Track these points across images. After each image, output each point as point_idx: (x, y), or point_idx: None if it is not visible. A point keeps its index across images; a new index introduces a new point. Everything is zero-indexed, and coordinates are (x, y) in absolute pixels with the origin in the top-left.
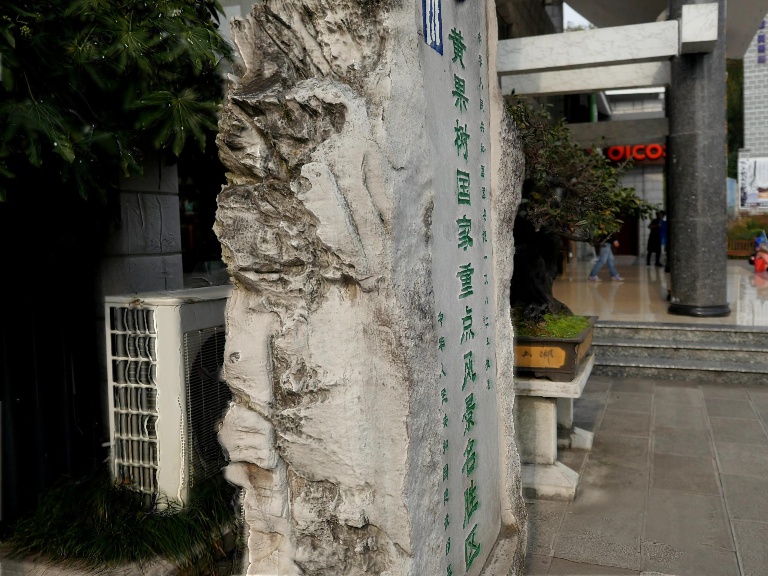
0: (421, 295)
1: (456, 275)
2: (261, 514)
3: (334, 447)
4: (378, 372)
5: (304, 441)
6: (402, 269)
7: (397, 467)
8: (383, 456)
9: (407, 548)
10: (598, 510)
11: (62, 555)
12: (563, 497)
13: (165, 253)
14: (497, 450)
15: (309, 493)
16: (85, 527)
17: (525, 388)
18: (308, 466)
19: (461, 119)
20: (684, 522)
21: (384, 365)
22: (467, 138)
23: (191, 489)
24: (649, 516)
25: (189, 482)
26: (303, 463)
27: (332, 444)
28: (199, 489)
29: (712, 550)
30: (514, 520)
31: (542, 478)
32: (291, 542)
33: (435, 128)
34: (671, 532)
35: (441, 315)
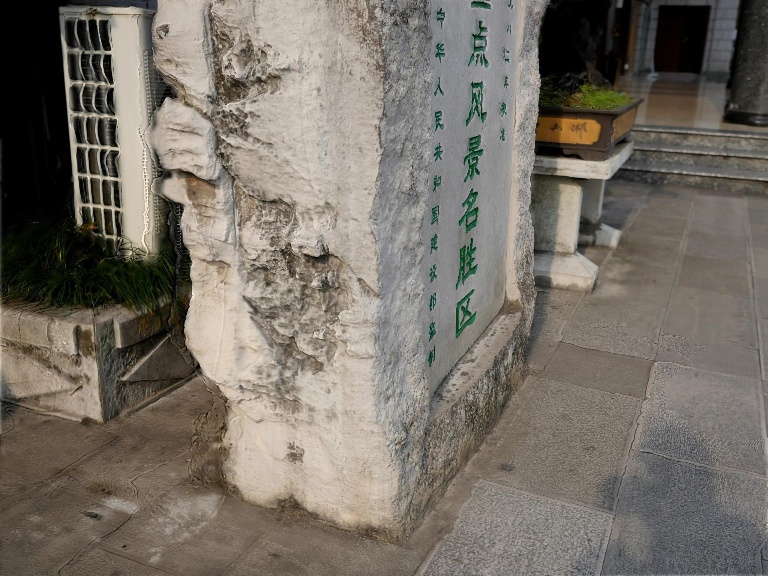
0: None
1: None
2: (201, 237)
3: (287, 154)
4: (344, 56)
5: (250, 145)
6: None
7: (365, 185)
8: (348, 170)
9: (374, 285)
10: (617, 302)
11: (6, 290)
12: (580, 287)
13: None
14: (507, 216)
15: (261, 217)
16: (35, 265)
17: (551, 166)
18: (257, 180)
19: None
20: (710, 319)
21: (353, 47)
22: None
23: (157, 235)
24: (672, 311)
25: (154, 227)
26: (251, 176)
27: (284, 150)
28: (167, 237)
29: (738, 347)
30: (520, 295)
31: (560, 267)
32: (240, 274)
33: None
34: (694, 327)
35: (442, 14)
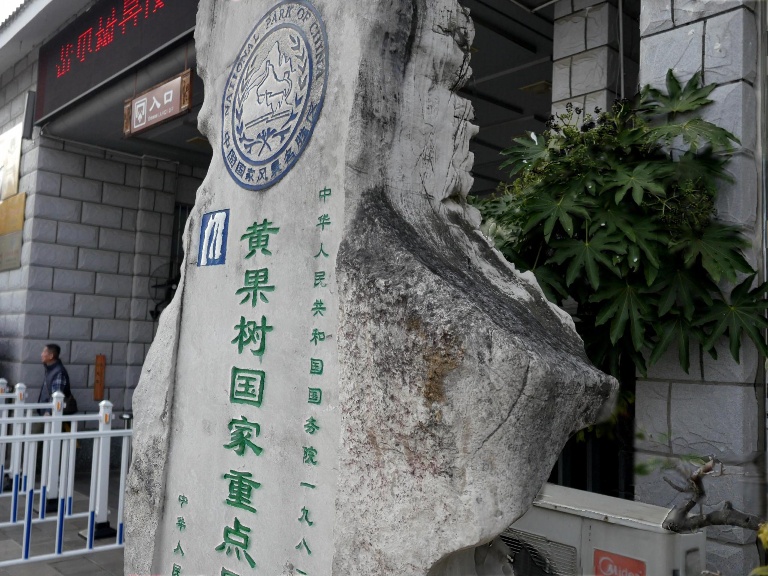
0: (143, 461)
1: None
2: None
3: None
4: None
5: None
6: None
7: None
8: None
9: None
10: None
11: None
12: None
13: None
14: None
15: None
16: None
17: None
18: None
19: (252, 313)
20: None
21: None
22: None
23: None
24: None
25: None
26: None
27: None
28: None
29: None
30: None
31: None
32: None
33: (200, 333)
34: None
35: None
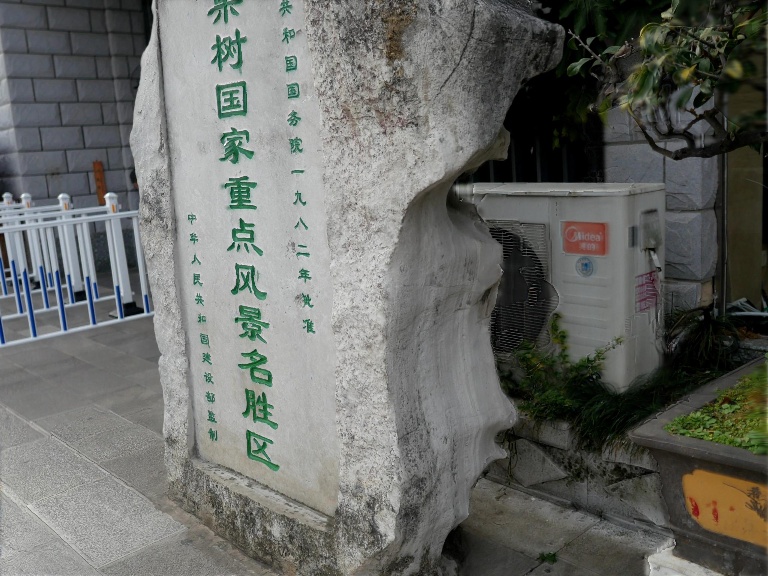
0: None
1: (225, 186)
2: None
3: None
4: None
5: None
6: None
7: None
8: None
9: None
10: None
11: None
12: None
13: (641, 141)
14: None
15: None
16: None
17: None
18: None
19: (226, 29)
20: None
21: None
22: (241, 43)
23: None
24: None
25: None
26: None
27: None
28: None
29: None
30: None
31: None
32: None
33: (181, 63)
34: None
35: None
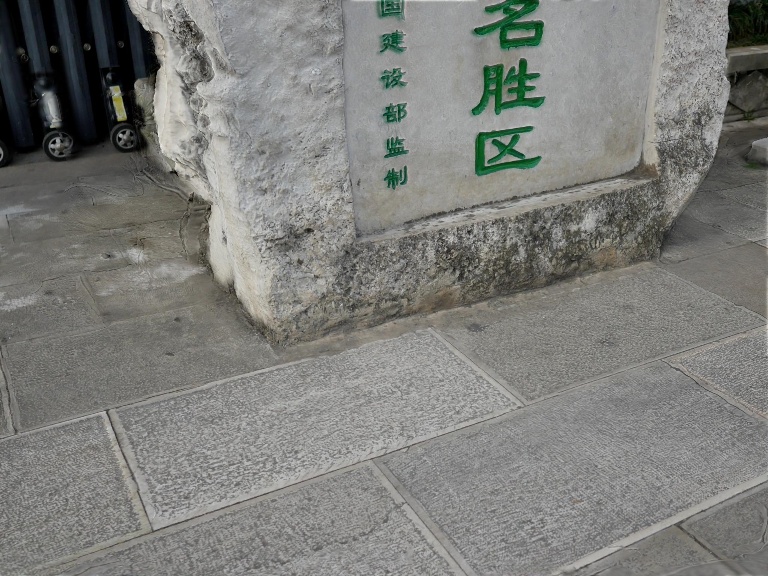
0: None
1: None
2: None
3: None
4: None
5: None
6: None
7: None
8: None
9: (225, 57)
10: None
11: None
12: None
13: None
14: (650, 51)
15: None
16: None
17: None
18: None
19: None
20: None
21: None
22: None
23: None
24: None
25: None
26: None
27: None
28: None
29: None
30: (657, 159)
31: None
32: (174, 47)
33: None
34: None
35: None
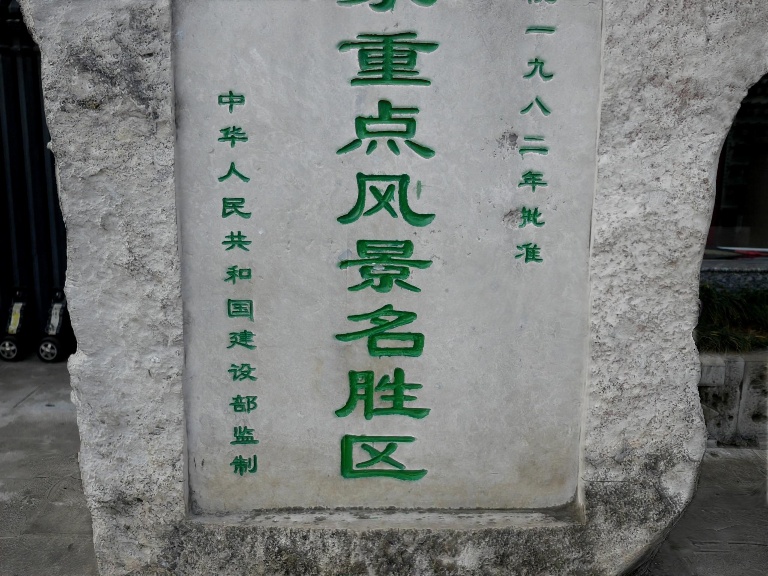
0: (102, 54)
1: (339, 48)
2: None
3: None
4: None
5: None
6: (59, 19)
7: None
8: None
9: None
10: None
11: None
12: None
13: None
14: (580, 376)
15: None
16: None
17: None
18: None
19: None
20: None
21: None
22: None
23: None
24: None
25: None
26: None
27: None
28: None
29: None
30: (585, 500)
31: None
32: None
33: None
34: None
35: (239, 97)
